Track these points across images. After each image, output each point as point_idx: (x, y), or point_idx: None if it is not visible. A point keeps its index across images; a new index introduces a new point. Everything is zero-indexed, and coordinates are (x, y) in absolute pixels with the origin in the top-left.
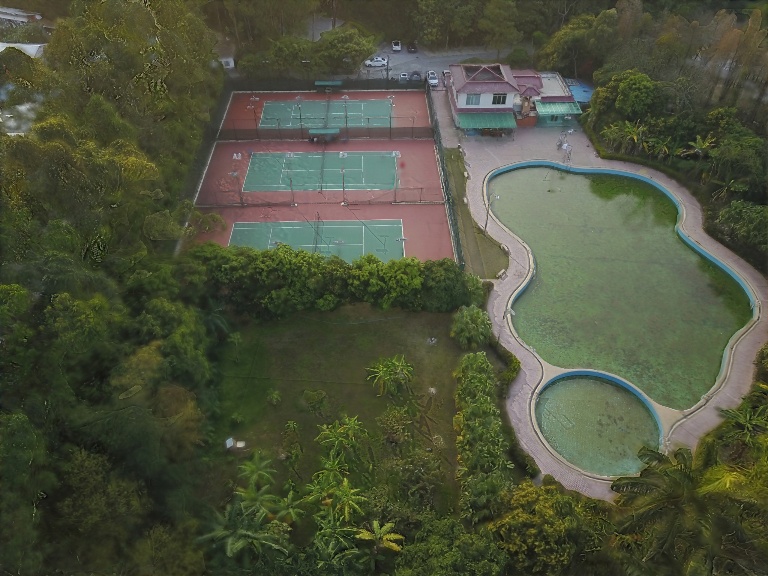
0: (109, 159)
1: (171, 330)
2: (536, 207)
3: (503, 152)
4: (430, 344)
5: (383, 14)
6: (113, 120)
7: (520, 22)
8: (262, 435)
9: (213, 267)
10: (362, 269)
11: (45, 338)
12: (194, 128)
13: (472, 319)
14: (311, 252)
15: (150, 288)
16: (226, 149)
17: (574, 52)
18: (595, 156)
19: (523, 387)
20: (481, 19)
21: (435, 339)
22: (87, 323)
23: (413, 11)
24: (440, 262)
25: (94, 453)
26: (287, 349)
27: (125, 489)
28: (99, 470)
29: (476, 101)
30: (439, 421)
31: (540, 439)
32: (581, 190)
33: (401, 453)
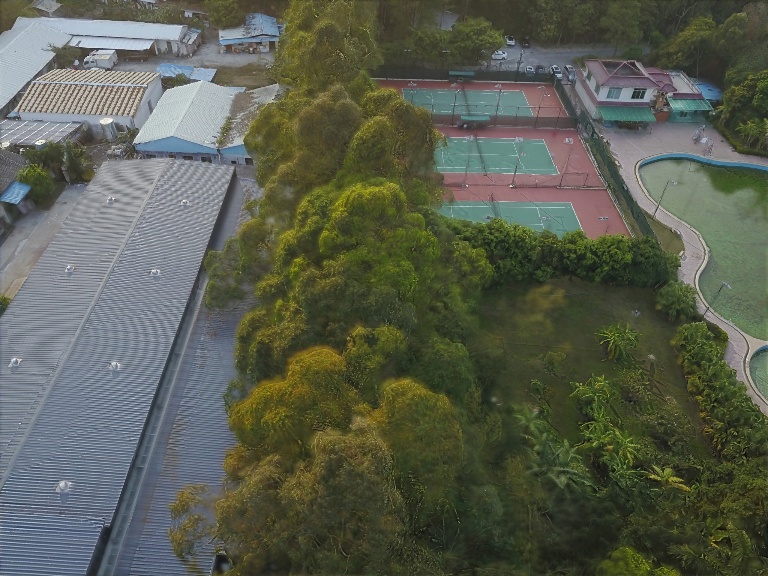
0: None
1: (448, 289)
2: (690, 196)
3: (644, 144)
4: (635, 316)
5: (496, 9)
6: None
7: None
8: None
9: None
10: (577, 244)
11: (432, 282)
12: None
13: (682, 293)
14: None
15: None
16: None
17: (699, 52)
18: (732, 151)
19: (734, 356)
20: (603, 18)
21: (639, 311)
22: (488, 268)
23: (529, 8)
24: (644, 240)
25: (478, 386)
26: (504, 316)
27: (499, 420)
28: (479, 402)
29: (616, 95)
30: (667, 384)
31: (764, 402)
32: (727, 182)
33: (642, 411)
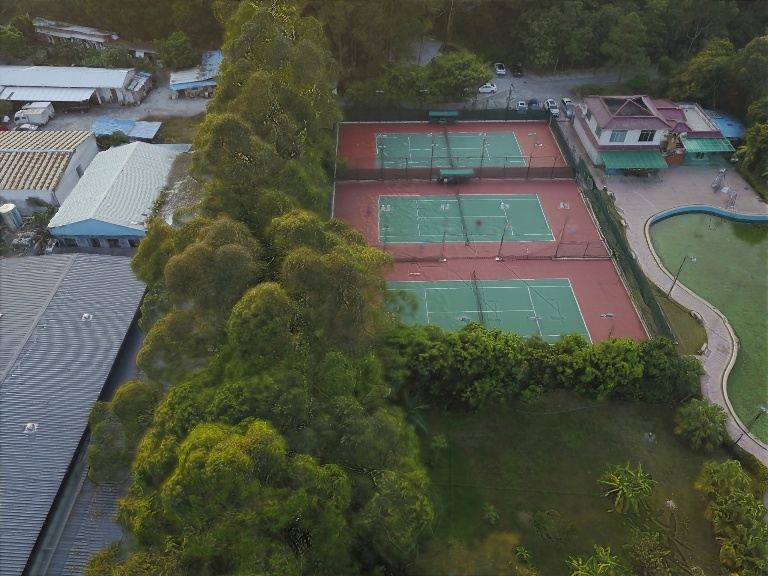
0: (357, 256)
1: (401, 452)
2: (711, 263)
3: (655, 195)
4: (649, 441)
5: (484, 34)
6: (309, 189)
7: (638, 45)
8: (487, 565)
9: (409, 356)
10: (573, 355)
11: None
12: (320, 170)
13: (708, 416)
14: (478, 320)
15: (365, 395)
16: (348, 191)
17: (715, 81)
18: (758, 201)
19: None
20: (604, 43)
21: (653, 434)
22: (425, 514)
23: (521, 32)
24: (658, 344)
25: None
26: (485, 447)
27: None
28: None
29: (621, 138)
30: (692, 546)
31: None
32: (755, 242)
33: None
